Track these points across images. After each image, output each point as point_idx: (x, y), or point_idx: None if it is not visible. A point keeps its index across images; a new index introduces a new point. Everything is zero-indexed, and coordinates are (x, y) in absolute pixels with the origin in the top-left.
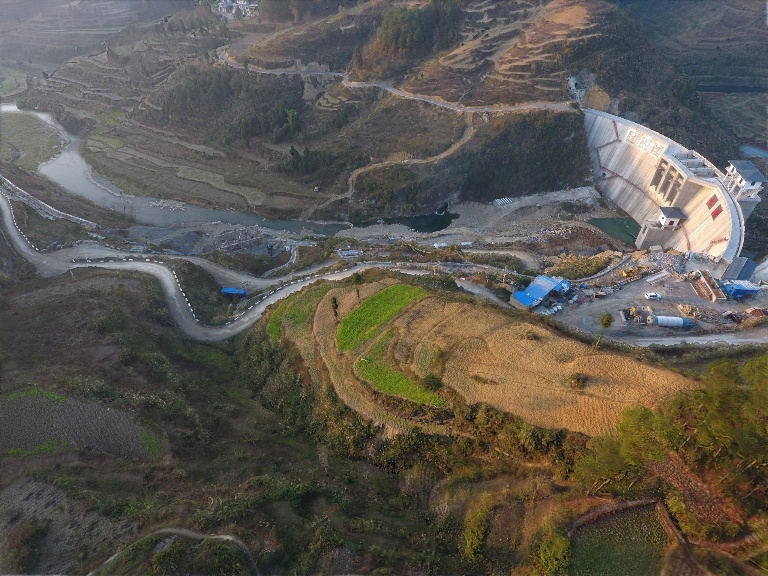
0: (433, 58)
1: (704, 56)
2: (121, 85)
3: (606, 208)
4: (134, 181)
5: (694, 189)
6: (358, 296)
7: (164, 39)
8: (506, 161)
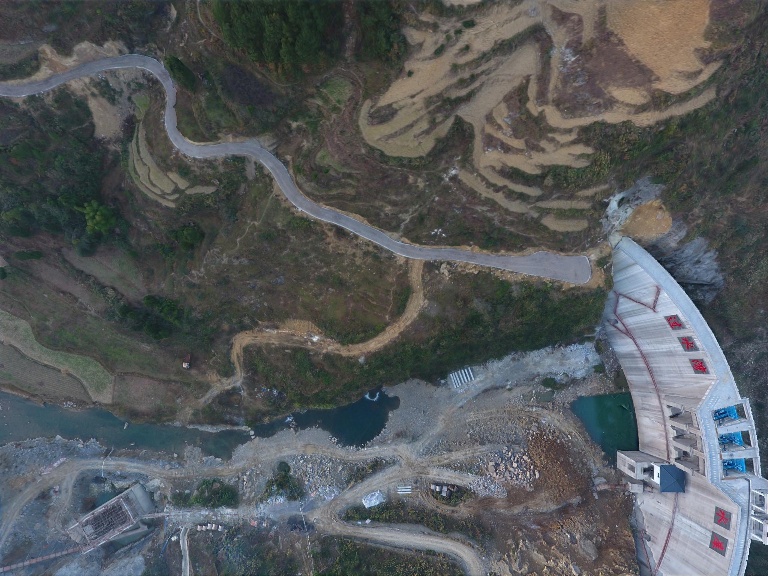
0: (347, 78)
1: None
2: None
3: (601, 373)
4: None
5: None
6: None
7: None
8: None
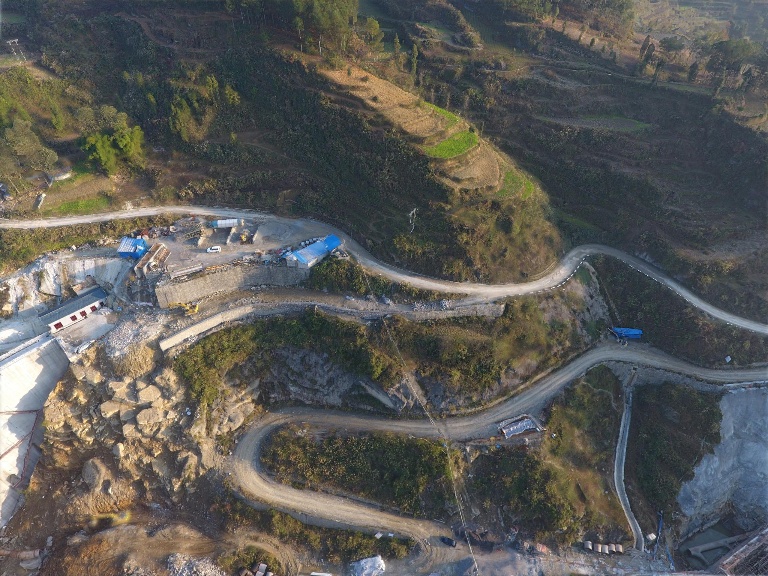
0: None
1: None
2: None
3: None
4: None
5: None
6: None
7: None
8: None
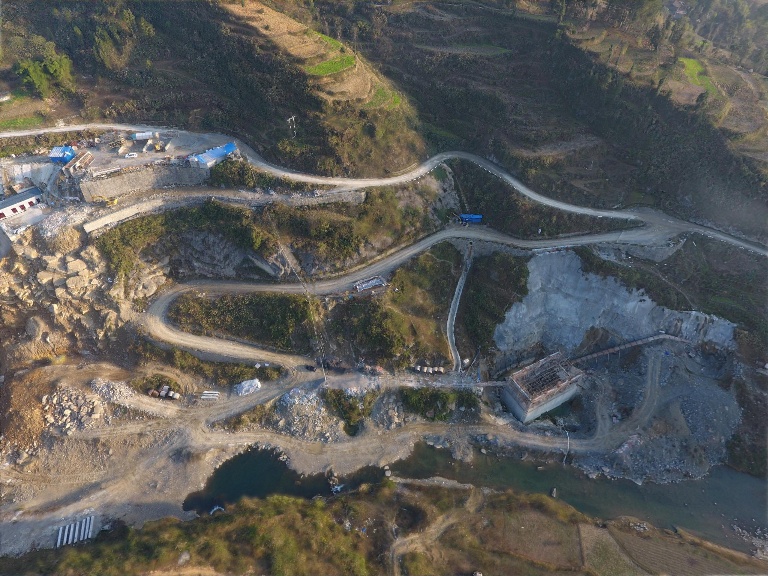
0: None
1: None
2: None
3: None
4: None
5: None
6: None
7: None
8: None
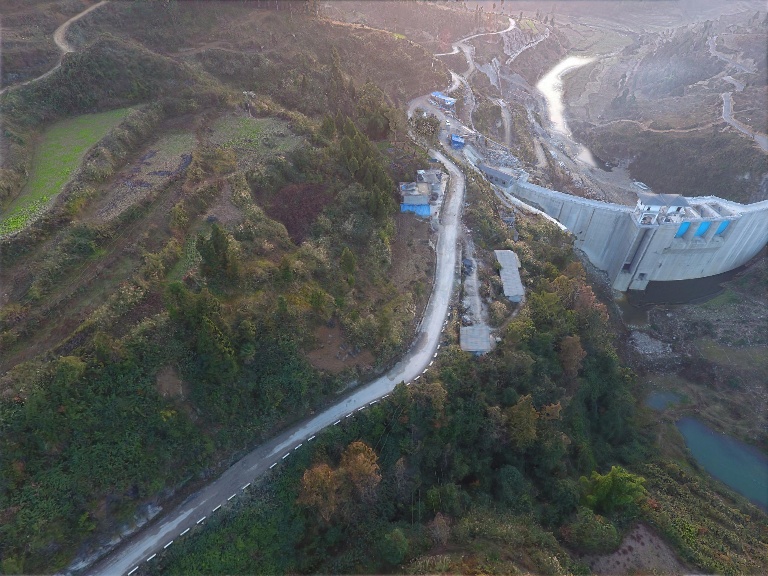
0: None
1: None
2: None
3: None
4: None
5: None
6: None
7: None
8: None
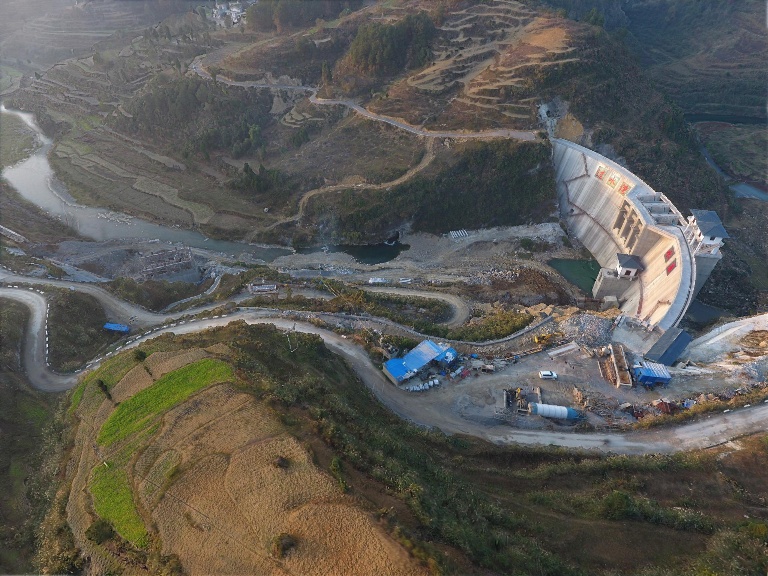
0: (404, 77)
1: (712, 82)
2: (102, 90)
3: (570, 247)
4: (89, 190)
5: (654, 237)
6: (149, 373)
7: (150, 45)
8: (464, 191)
